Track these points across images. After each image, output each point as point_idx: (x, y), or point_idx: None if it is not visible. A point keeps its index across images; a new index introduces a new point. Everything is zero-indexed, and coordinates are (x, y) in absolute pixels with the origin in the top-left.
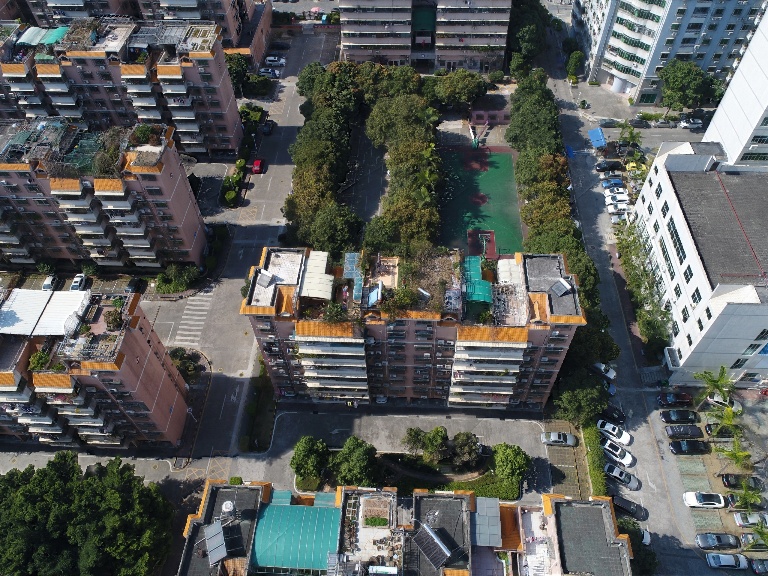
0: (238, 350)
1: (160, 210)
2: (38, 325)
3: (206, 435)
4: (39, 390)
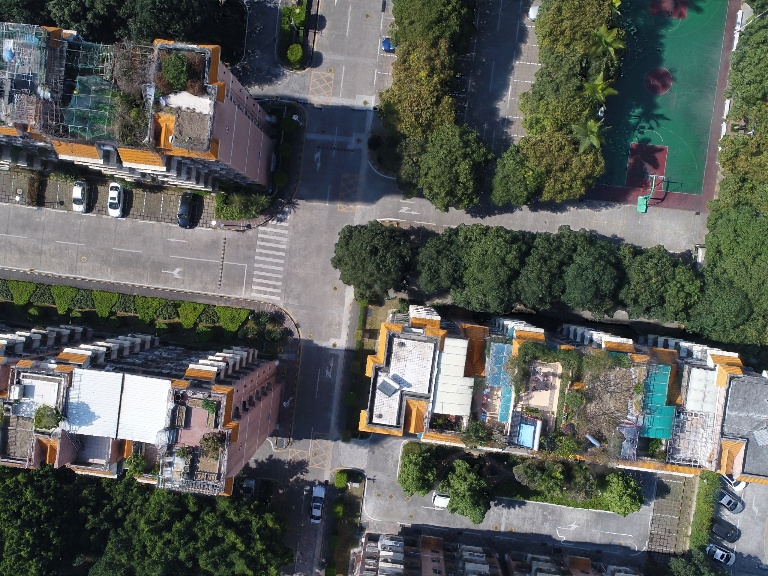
0: (328, 312)
1: (216, 166)
2: (120, 425)
3: (304, 415)
4: (142, 481)
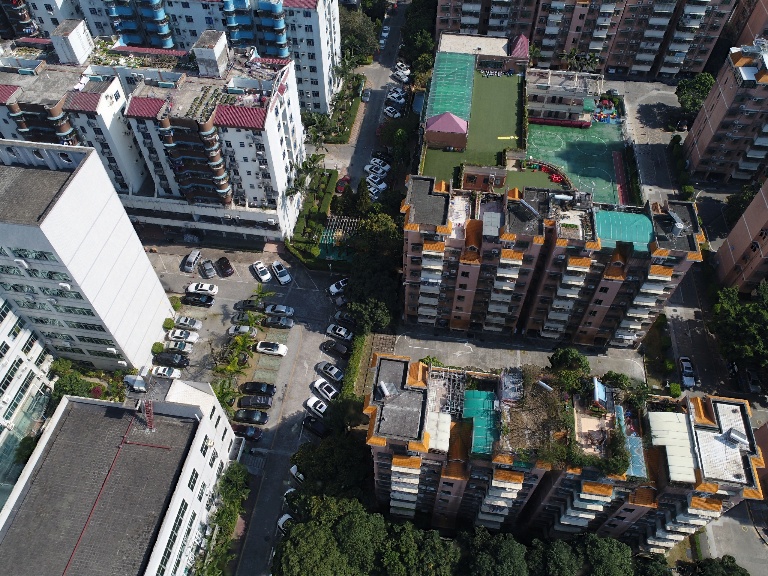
0: (735, 556)
1: None
2: None
3: None
4: None
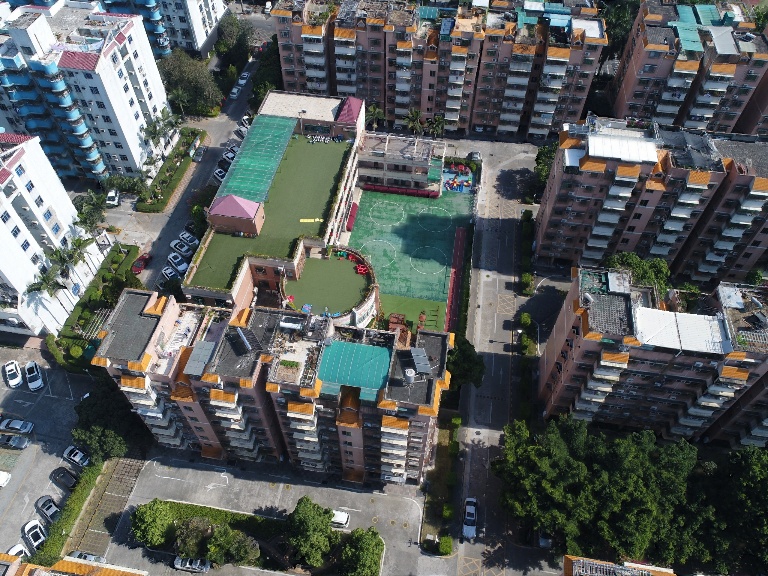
0: None
1: None
2: None
3: None
4: (668, 571)
